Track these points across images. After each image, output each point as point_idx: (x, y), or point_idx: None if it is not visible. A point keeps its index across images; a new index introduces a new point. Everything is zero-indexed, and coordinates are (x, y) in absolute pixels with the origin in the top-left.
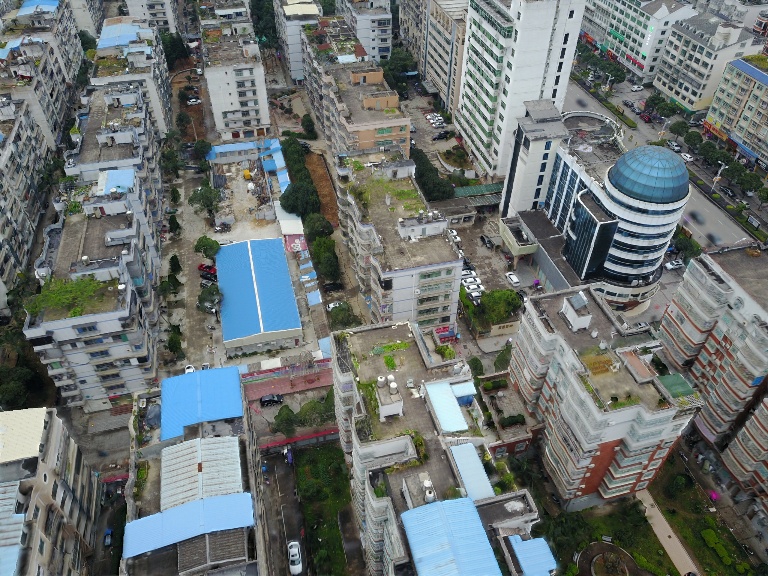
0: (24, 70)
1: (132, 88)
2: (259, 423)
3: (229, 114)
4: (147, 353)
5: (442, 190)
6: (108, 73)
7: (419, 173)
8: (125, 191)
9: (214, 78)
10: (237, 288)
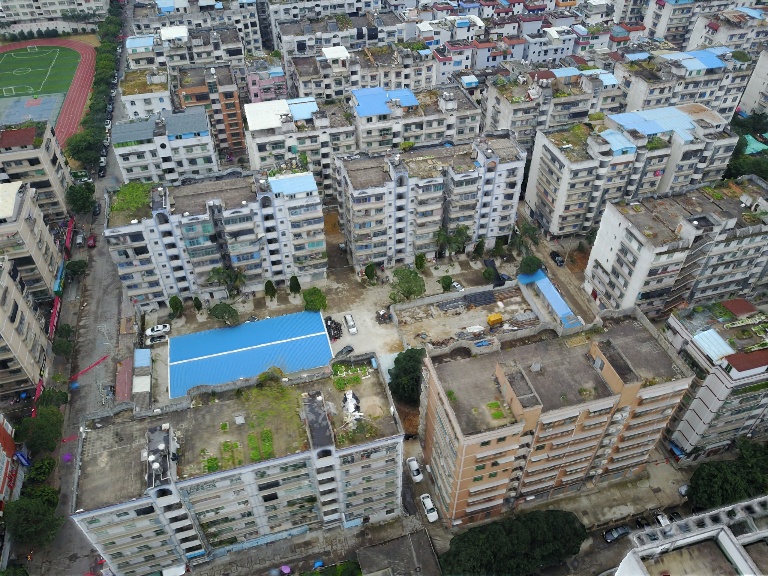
0: (537, 92)
1: (489, 152)
2: (87, 390)
3: (600, 268)
4: (121, 274)
5: (445, 569)
6: (561, 138)
7: (490, 527)
8: (273, 191)
9: (608, 218)
10: (246, 335)
